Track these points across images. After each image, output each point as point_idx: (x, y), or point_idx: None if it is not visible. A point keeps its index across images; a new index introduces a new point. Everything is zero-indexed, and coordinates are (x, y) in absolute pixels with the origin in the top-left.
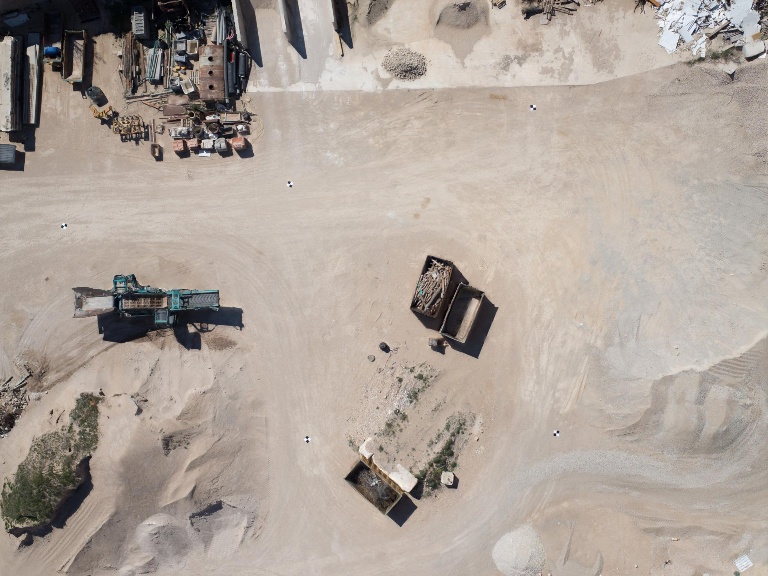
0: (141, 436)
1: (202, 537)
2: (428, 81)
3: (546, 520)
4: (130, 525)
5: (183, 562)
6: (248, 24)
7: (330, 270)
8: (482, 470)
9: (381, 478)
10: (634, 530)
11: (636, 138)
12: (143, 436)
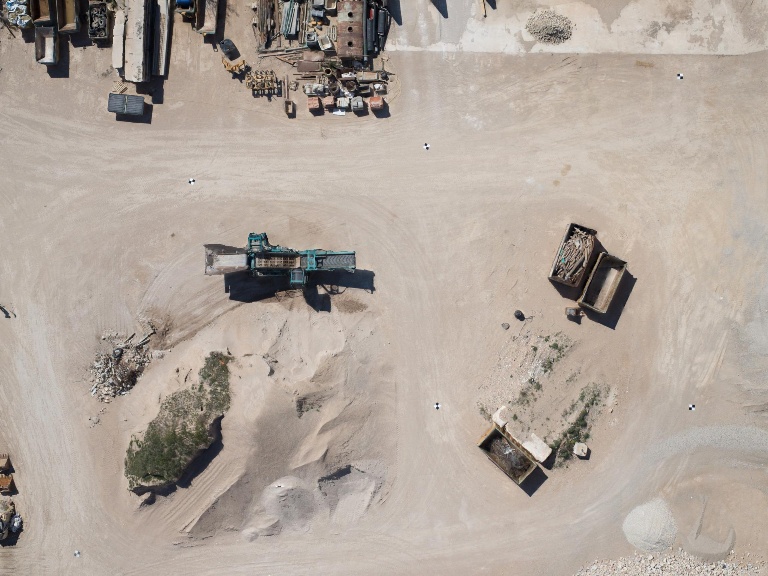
0: (275, 397)
1: (328, 501)
2: (573, 45)
3: (679, 494)
4: (258, 487)
5: (307, 526)
6: None
7: (466, 235)
8: (615, 442)
9: (516, 447)
10: (767, 507)
11: None
12: (277, 397)
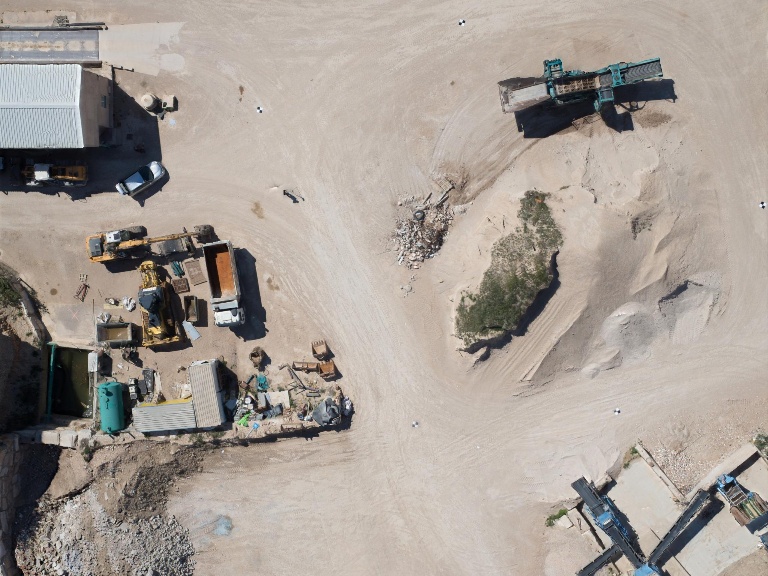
0: (609, 222)
1: (668, 322)
2: None
3: None
4: (598, 320)
5: (648, 352)
6: None
7: (765, 21)
8: None
9: None
10: None
11: None
12: (611, 222)
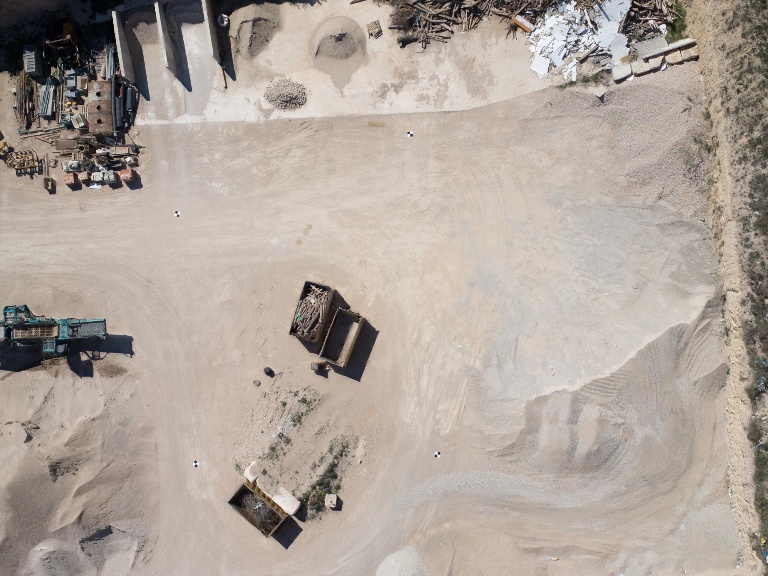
0: (28, 463)
1: (94, 561)
2: (308, 110)
3: (428, 541)
4: (22, 550)
5: None
6: (136, 59)
7: (216, 297)
8: (365, 492)
9: (263, 501)
10: (515, 550)
11: (510, 162)
12: (30, 463)
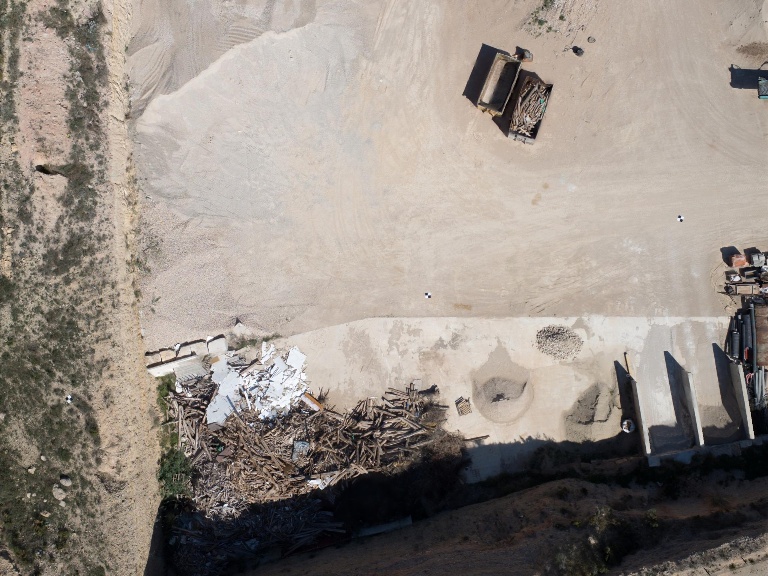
0: None
1: None
2: (535, 325)
3: None
4: None
5: None
6: (730, 390)
7: (636, 129)
8: None
9: None
10: None
11: (328, 264)
12: None
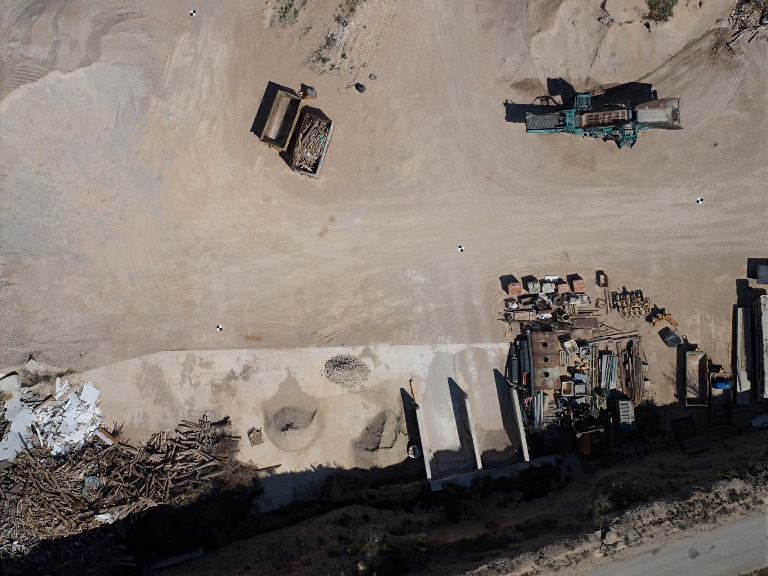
0: None
1: None
2: (323, 355)
3: None
4: None
5: None
6: (510, 414)
7: (417, 163)
8: None
9: None
10: None
11: (121, 299)
12: None
